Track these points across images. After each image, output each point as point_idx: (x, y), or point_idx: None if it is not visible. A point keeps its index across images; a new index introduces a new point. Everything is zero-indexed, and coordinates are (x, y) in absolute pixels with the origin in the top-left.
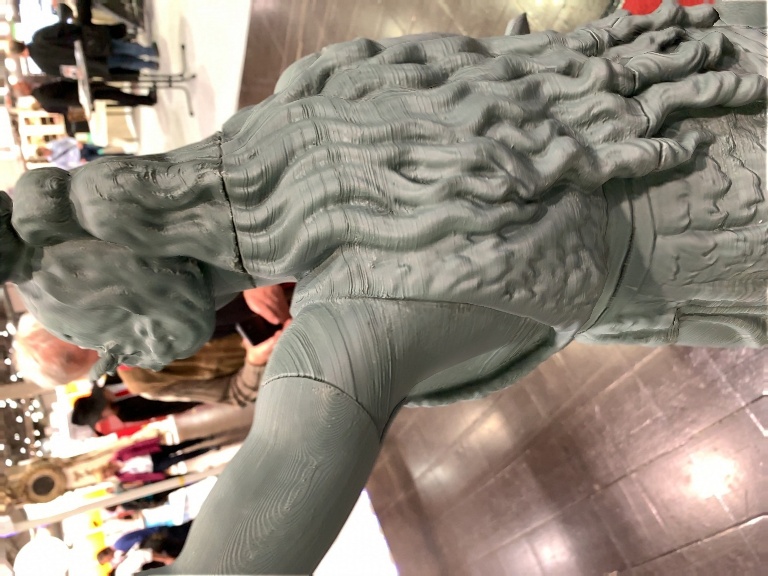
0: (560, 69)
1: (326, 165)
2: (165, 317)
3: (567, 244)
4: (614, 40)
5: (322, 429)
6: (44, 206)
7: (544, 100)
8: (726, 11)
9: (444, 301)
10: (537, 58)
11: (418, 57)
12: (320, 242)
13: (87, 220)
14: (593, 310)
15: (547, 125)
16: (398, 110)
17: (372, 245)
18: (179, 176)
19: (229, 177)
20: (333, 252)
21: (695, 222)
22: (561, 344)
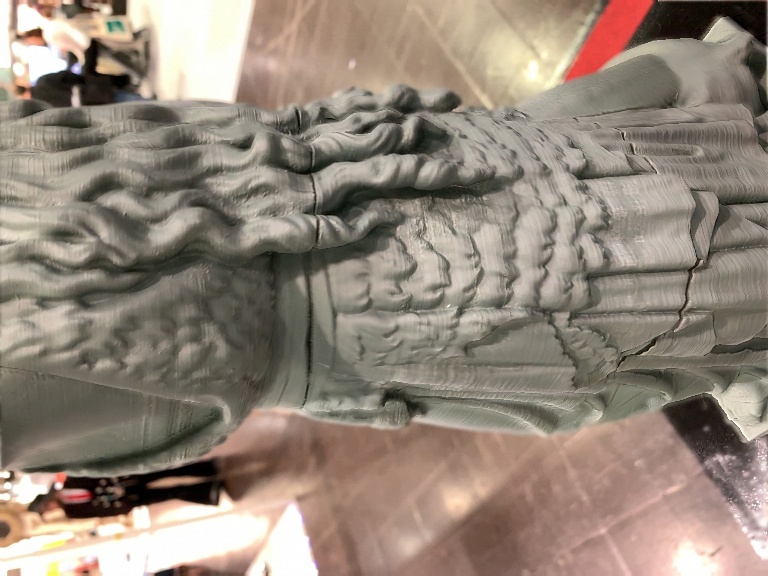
0: (237, 142)
1: None
2: None
3: (181, 316)
4: (323, 118)
5: None
6: None
7: (199, 171)
8: (545, 100)
9: (7, 367)
10: (219, 130)
11: (78, 121)
12: None
13: None
14: (295, 386)
15: (178, 195)
16: (2, 170)
17: None
18: None
19: None
20: None
21: (377, 302)
22: (229, 419)
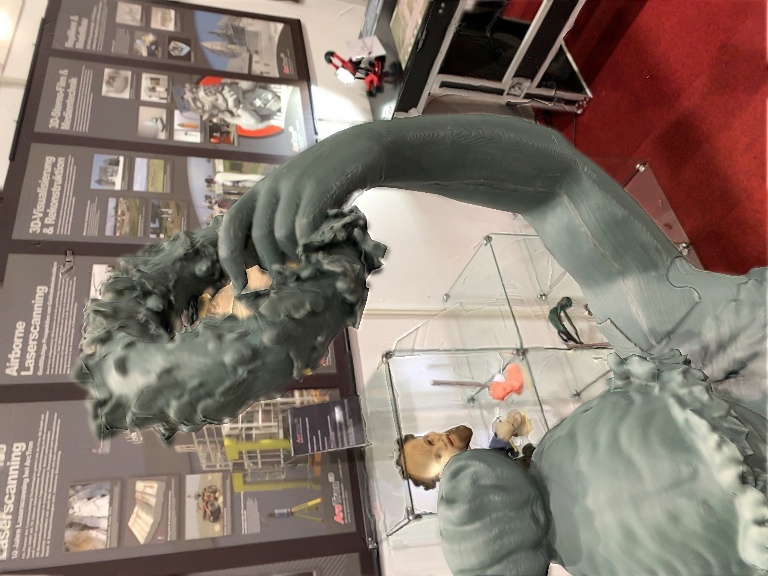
0: None
1: None
2: None
3: None
4: None
5: None
6: None
7: None
8: None
9: None
10: None
11: None
12: None
13: None
14: None
15: None
16: None
17: None
18: None
19: None
20: None
21: None
22: None
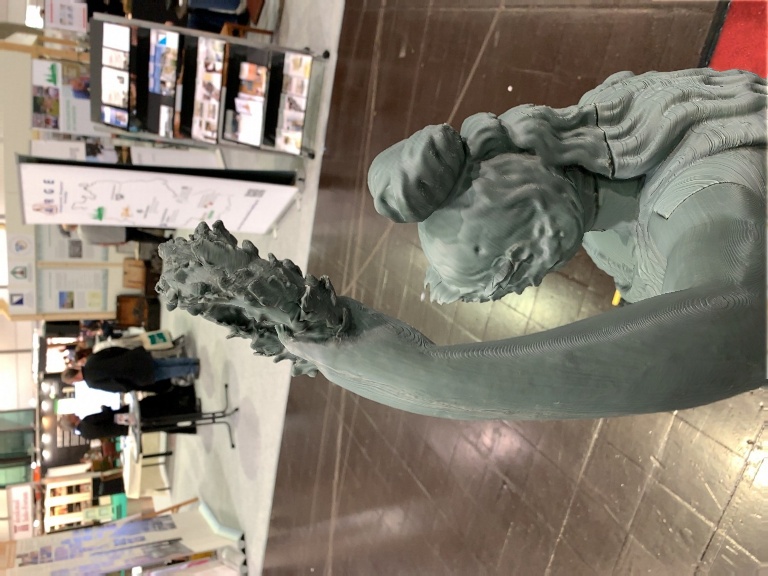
0: None
1: (663, 88)
2: (560, 213)
3: None
4: None
5: (744, 204)
6: (493, 123)
7: None
8: None
9: None
10: None
11: None
12: (678, 124)
13: (517, 133)
14: None
15: None
16: None
17: (717, 117)
18: (567, 109)
19: (600, 105)
20: (684, 136)
21: None
22: None
